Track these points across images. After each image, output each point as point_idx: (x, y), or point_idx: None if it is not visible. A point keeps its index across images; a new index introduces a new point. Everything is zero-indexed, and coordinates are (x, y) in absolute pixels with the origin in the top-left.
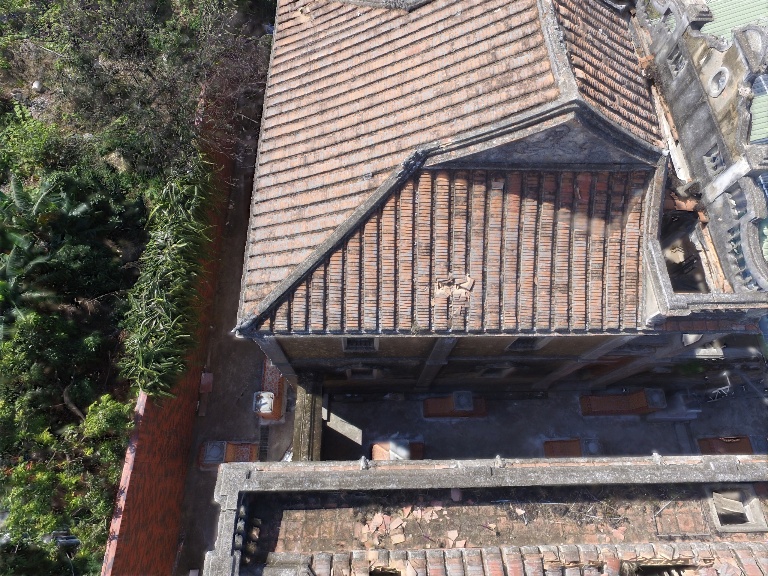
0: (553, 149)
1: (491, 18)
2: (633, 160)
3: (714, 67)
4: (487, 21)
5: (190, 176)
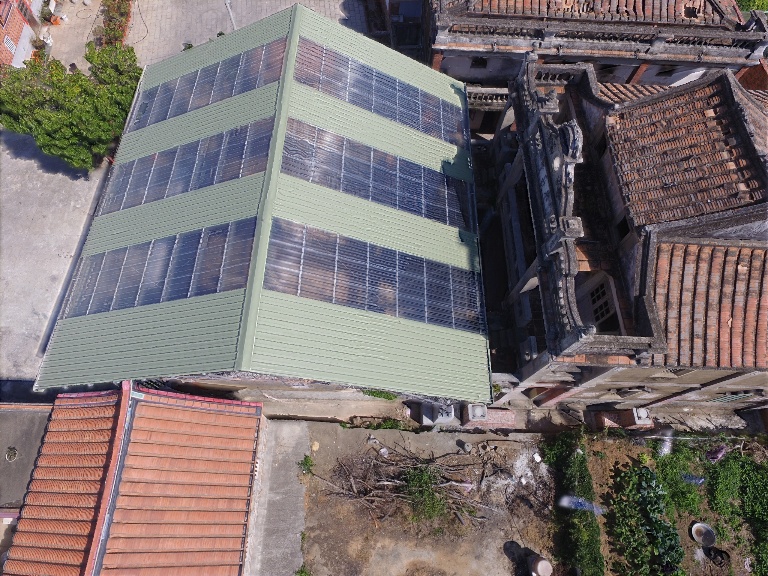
0: None
1: None
2: None
3: None
4: None
5: None
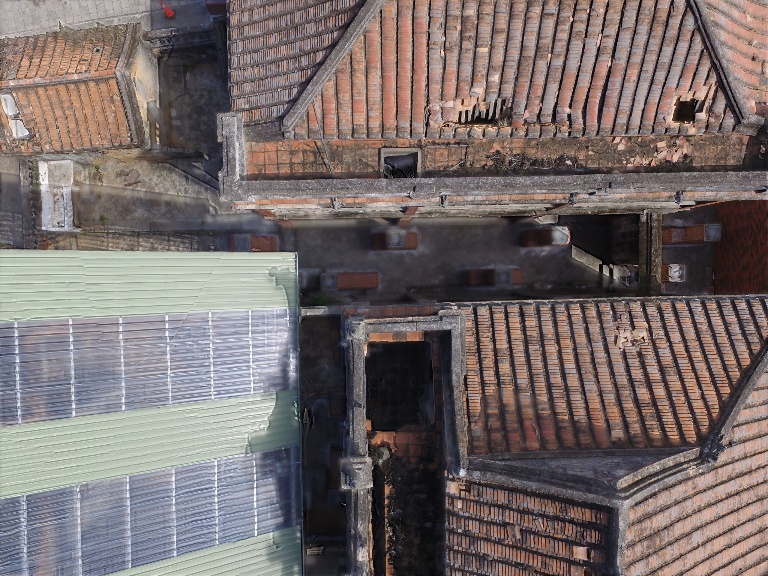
0: None
1: None
2: None
3: None
4: None
5: None
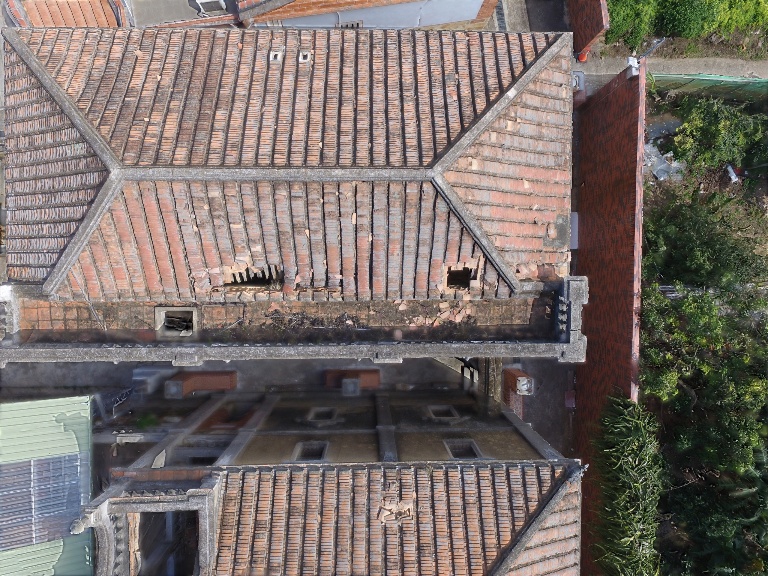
0: None
1: None
2: None
3: None
4: None
5: None
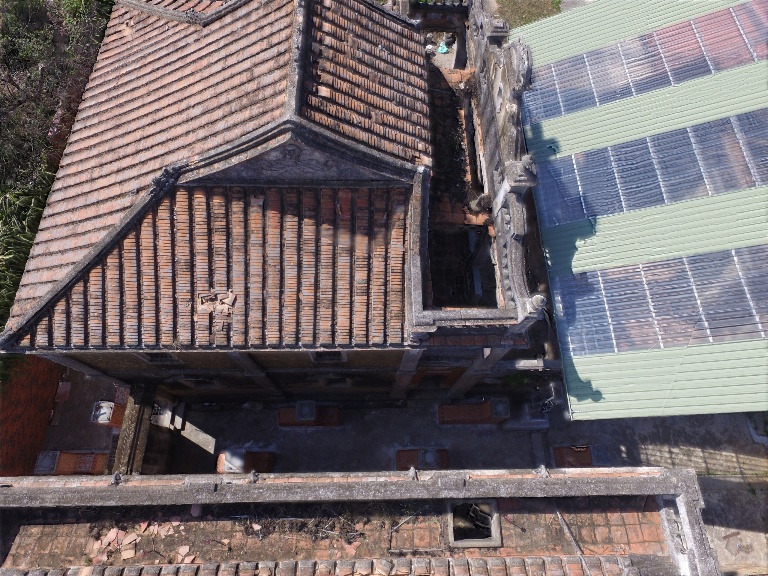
0: (300, 167)
1: (258, 35)
2: (386, 177)
3: (497, 83)
4: (255, 38)
5: (29, 187)
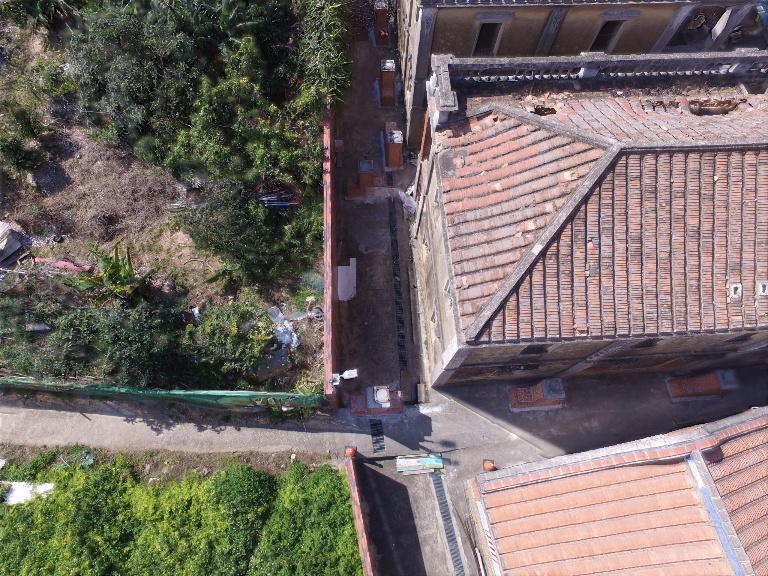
0: None
1: None
2: None
3: None
4: None
5: None
